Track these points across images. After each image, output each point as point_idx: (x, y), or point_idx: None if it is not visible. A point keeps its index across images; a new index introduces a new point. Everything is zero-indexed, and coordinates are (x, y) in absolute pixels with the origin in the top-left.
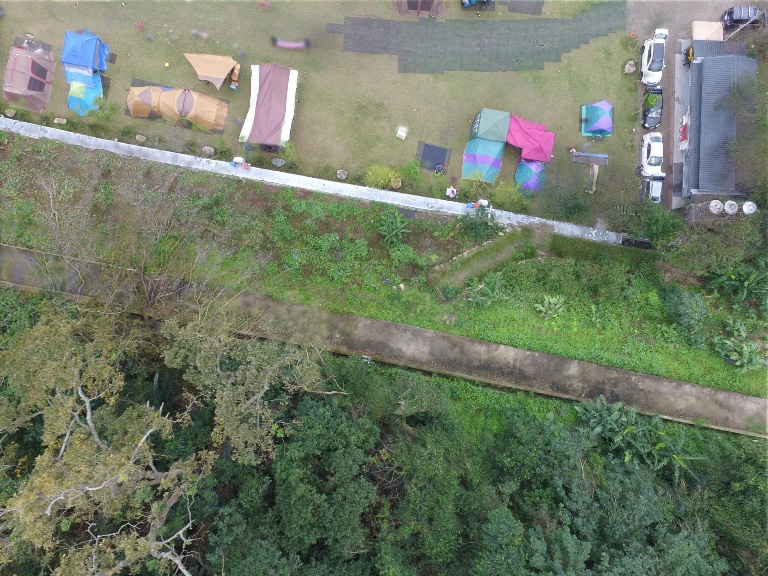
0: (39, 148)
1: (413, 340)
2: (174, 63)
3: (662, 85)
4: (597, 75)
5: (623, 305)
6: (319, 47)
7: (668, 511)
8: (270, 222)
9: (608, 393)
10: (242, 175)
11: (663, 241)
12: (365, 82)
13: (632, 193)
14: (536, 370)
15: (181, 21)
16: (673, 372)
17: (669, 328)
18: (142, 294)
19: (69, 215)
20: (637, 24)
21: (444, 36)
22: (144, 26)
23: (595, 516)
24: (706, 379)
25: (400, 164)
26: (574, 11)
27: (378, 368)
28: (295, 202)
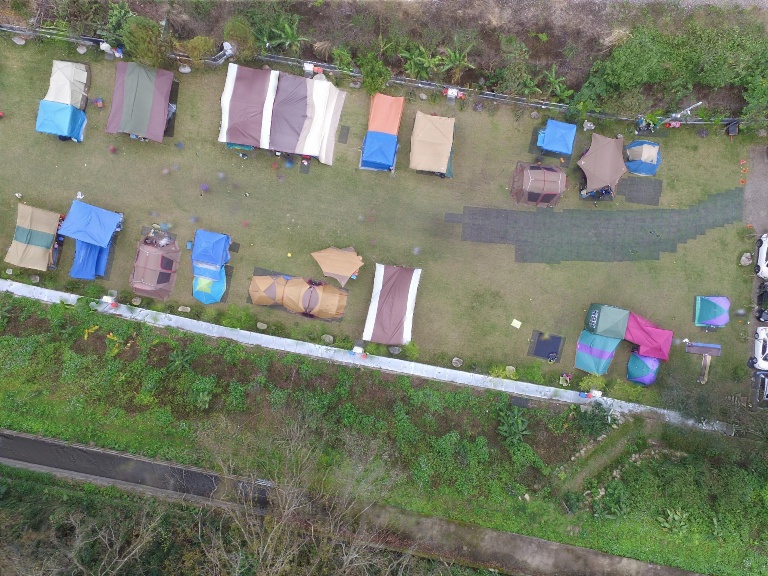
0: (166, 340)
1: (538, 552)
2: (296, 252)
3: None
4: (712, 266)
5: (740, 510)
6: (438, 236)
7: None
8: (393, 421)
9: None
10: (360, 362)
11: None
12: (482, 271)
13: (744, 384)
14: None
15: (303, 211)
16: None
17: None
18: (277, 507)
19: (206, 427)
20: (754, 215)
21: (561, 226)
22: (267, 216)
23: None
24: None
25: (514, 352)
26: (691, 202)
27: None
28: (412, 392)
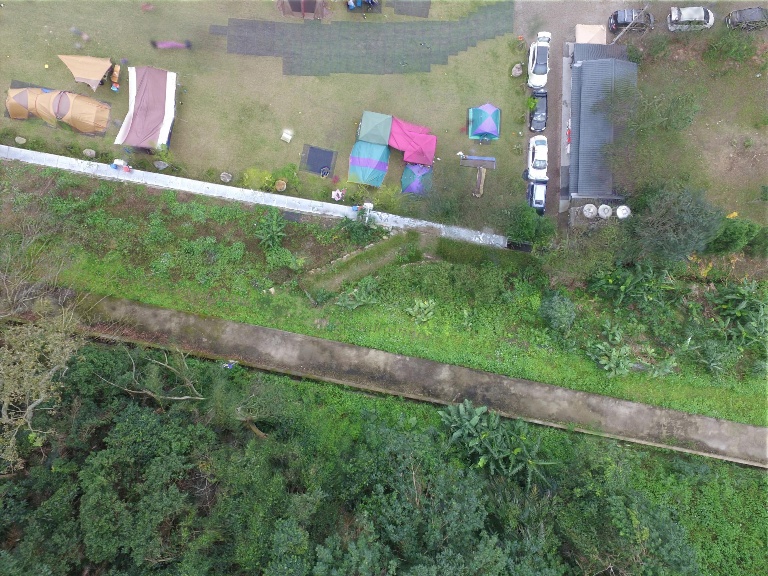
0: None
1: (282, 344)
2: (54, 64)
3: (550, 88)
4: (484, 78)
5: (501, 309)
6: (202, 49)
7: (513, 517)
8: (145, 225)
9: (480, 397)
10: (124, 178)
11: (537, 245)
12: (249, 84)
13: (519, 196)
14: (407, 374)
15: (61, 22)
16: (546, 376)
17: (542, 332)
18: (4, 298)
19: None
20: (525, 27)
21: (330, 38)
22: (23, 27)
23: (414, 523)
24: (579, 383)
25: None
26: (461, 13)
27: (245, 373)
28: (177, 205)
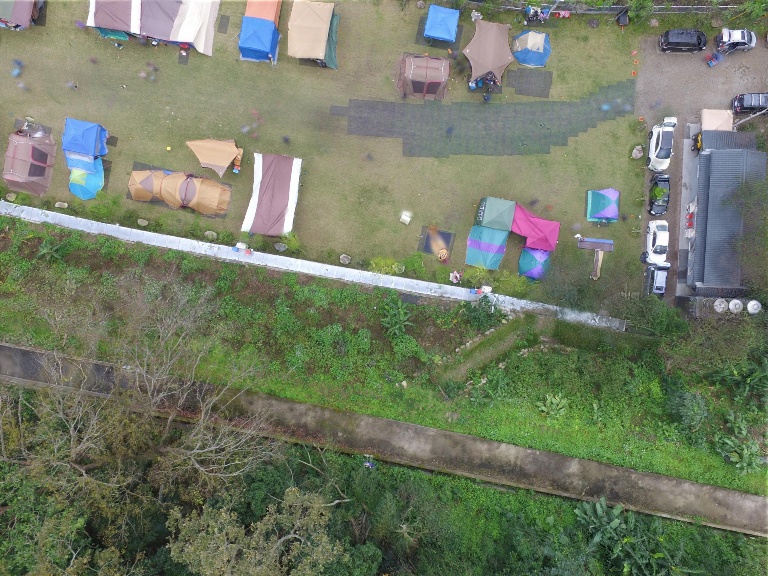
0: (40, 235)
1: (415, 438)
2: (176, 146)
3: (669, 170)
4: (604, 159)
5: (625, 399)
6: (323, 130)
7: None
8: (273, 313)
9: (608, 491)
10: (245, 260)
11: (666, 339)
12: (369, 166)
13: (636, 279)
14: (537, 468)
15: (183, 103)
16: (673, 470)
17: (670, 427)
18: (145, 393)
19: (71, 313)
20: (646, 108)
21: (450, 119)
22: (145, 108)
23: None
24: (706, 477)
25: (404, 249)
26: (582, 94)
27: (380, 467)
28: (298, 288)
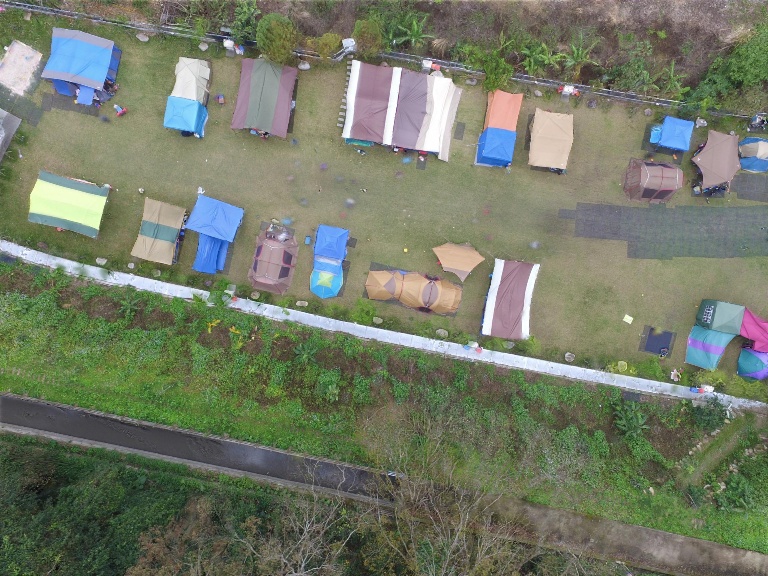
0: (286, 334)
1: (664, 545)
2: (411, 247)
3: None
4: None
5: None
6: (551, 232)
7: None
8: (513, 415)
9: None
10: (473, 357)
11: None
12: (595, 267)
13: None
14: None
15: (419, 206)
16: None
17: None
18: (407, 498)
19: (337, 419)
20: None
21: (673, 222)
22: (384, 211)
23: None
24: None
25: (626, 347)
26: None
27: None
28: (527, 386)
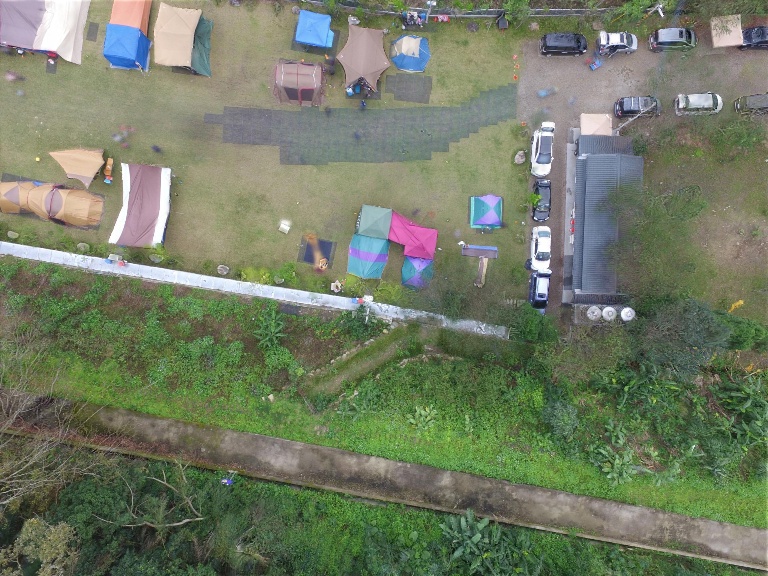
0: None
1: (281, 453)
2: (46, 157)
3: (553, 175)
4: (486, 165)
5: (503, 409)
6: (198, 138)
7: None
8: (141, 327)
9: (481, 503)
10: (119, 272)
11: (540, 348)
12: (246, 174)
13: (522, 286)
14: (408, 481)
15: (52, 113)
16: (548, 481)
17: (544, 437)
18: None
19: None
20: (528, 112)
21: (328, 126)
22: (13, 119)
23: None
24: (581, 488)
25: (283, 258)
26: (463, 99)
27: (245, 483)
28: (173, 300)
